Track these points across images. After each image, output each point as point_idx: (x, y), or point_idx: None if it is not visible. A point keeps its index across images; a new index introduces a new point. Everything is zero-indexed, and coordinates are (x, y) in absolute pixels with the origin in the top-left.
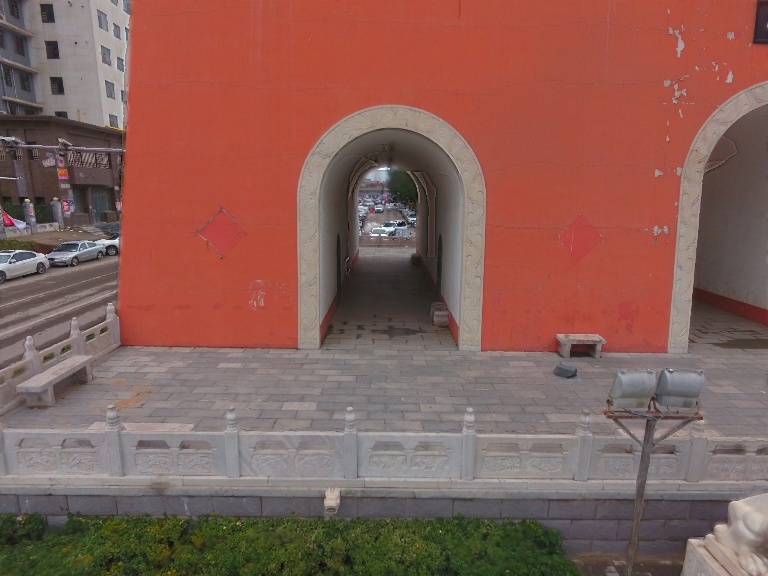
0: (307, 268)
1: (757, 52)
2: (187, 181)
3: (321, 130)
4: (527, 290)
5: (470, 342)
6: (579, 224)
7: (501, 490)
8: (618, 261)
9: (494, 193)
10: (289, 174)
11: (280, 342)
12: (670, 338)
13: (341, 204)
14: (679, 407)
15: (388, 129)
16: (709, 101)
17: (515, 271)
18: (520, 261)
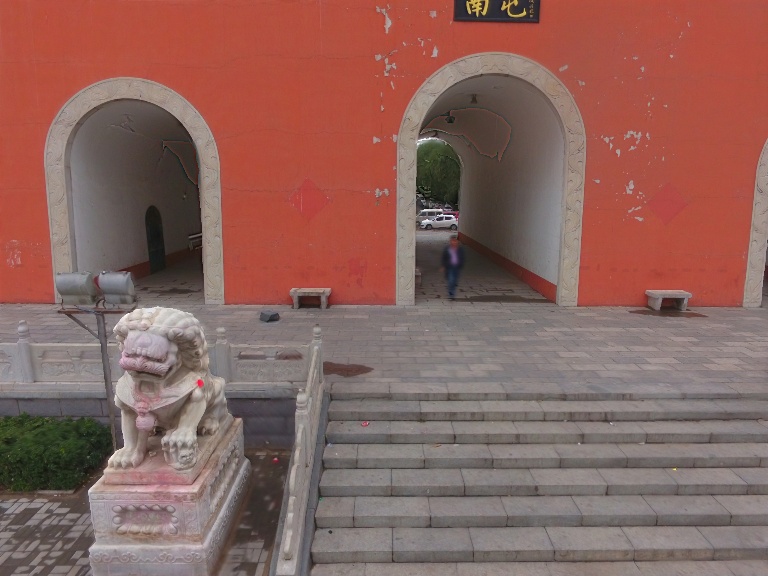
0: (58, 229)
1: (458, 29)
2: None
3: (62, 101)
4: (264, 248)
5: (214, 296)
6: (307, 187)
7: (55, 391)
8: (345, 221)
9: (227, 159)
10: (36, 141)
11: (39, 298)
12: (397, 291)
13: (163, 179)
14: (120, 304)
15: (124, 100)
16: (417, 74)
17: (251, 231)
18: (256, 221)
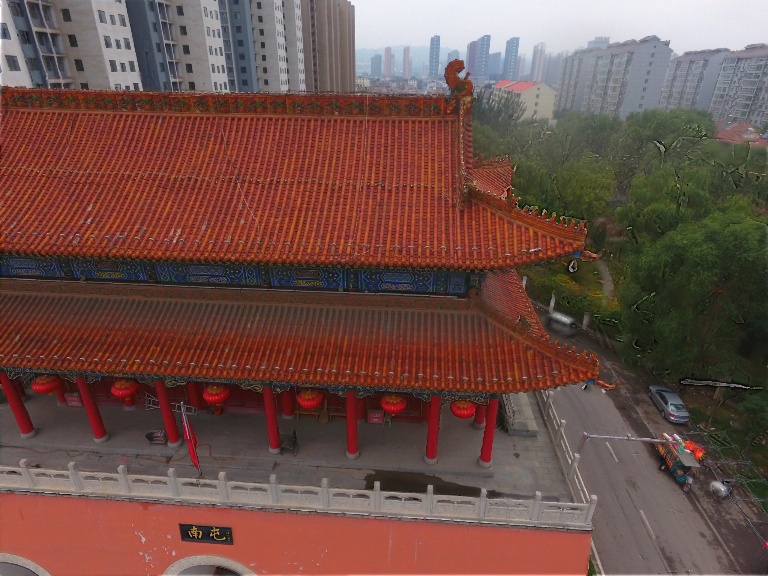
0: None
1: (185, 544)
2: None
3: None
4: None
5: None
6: None
7: None
8: None
9: None
10: None
11: None
12: None
13: None
14: None
15: (3, 562)
16: (165, 562)
17: None
18: None
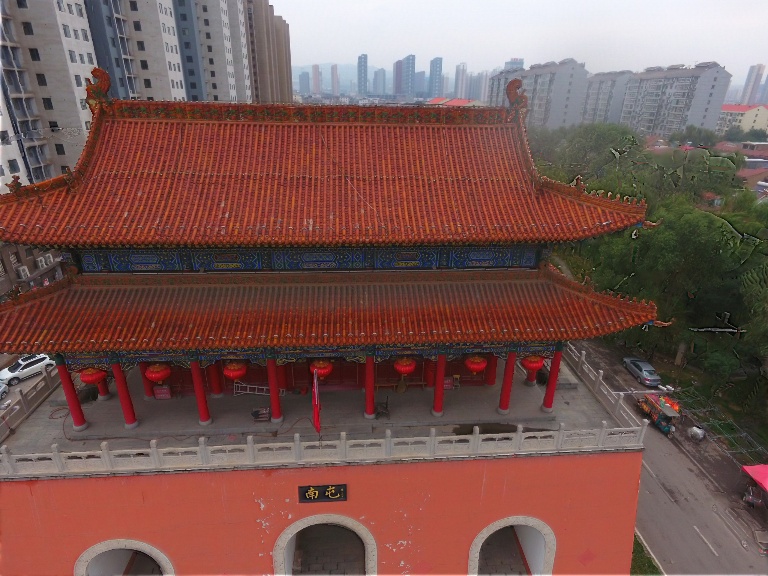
0: None
1: (302, 506)
2: (13, 575)
3: (81, 551)
4: None
5: None
6: None
7: None
8: None
9: (178, 568)
10: (68, 569)
11: None
12: None
13: None
14: None
15: (116, 549)
16: (281, 526)
17: None
18: None
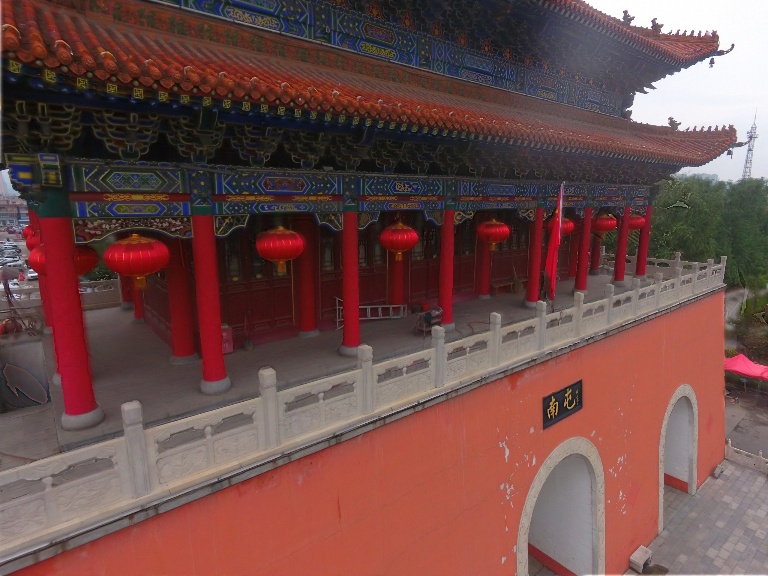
0: None
1: (545, 435)
2: None
3: None
4: None
5: None
6: None
7: None
8: None
9: None
10: None
11: None
12: None
13: None
14: None
15: None
16: (526, 485)
17: None
18: None
